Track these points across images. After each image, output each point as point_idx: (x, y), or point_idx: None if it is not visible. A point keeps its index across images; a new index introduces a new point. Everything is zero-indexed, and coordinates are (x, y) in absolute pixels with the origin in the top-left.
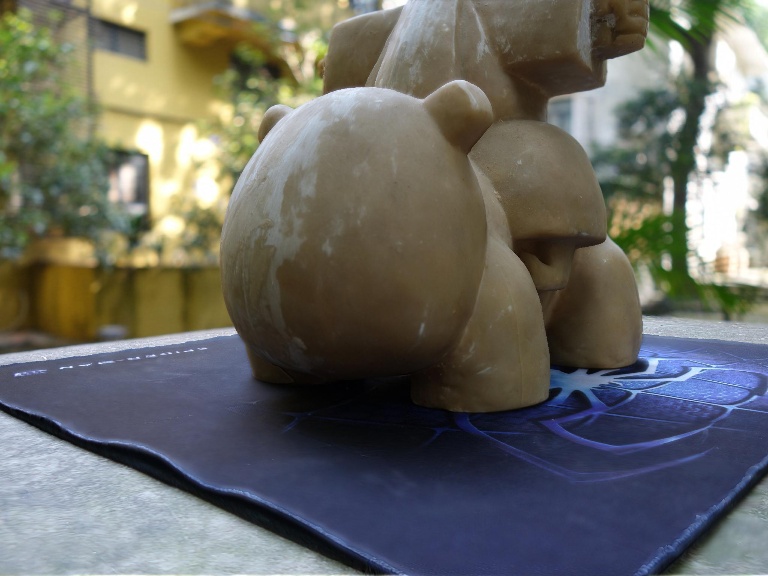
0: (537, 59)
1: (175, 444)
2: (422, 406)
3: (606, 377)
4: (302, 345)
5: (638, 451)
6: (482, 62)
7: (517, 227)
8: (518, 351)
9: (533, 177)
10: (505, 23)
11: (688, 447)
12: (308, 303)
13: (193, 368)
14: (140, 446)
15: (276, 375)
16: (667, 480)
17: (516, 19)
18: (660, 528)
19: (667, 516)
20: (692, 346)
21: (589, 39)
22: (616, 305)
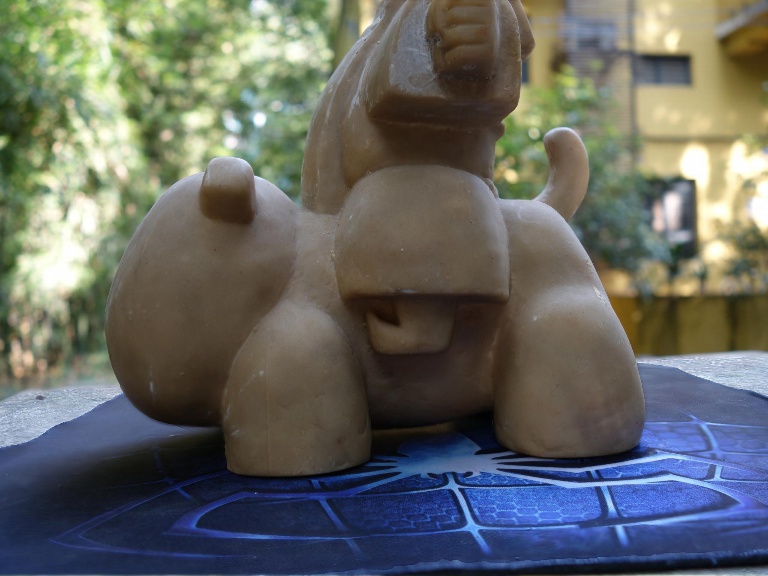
0: (376, 103)
1: (40, 454)
2: None
3: (494, 465)
4: None
5: (186, 536)
6: (352, 116)
7: (340, 287)
8: (266, 418)
9: (353, 233)
10: (370, 70)
11: (235, 547)
12: None
13: None
14: None
15: None
16: (96, 562)
17: None
18: None
19: None
20: None
21: (429, 65)
22: (538, 376)
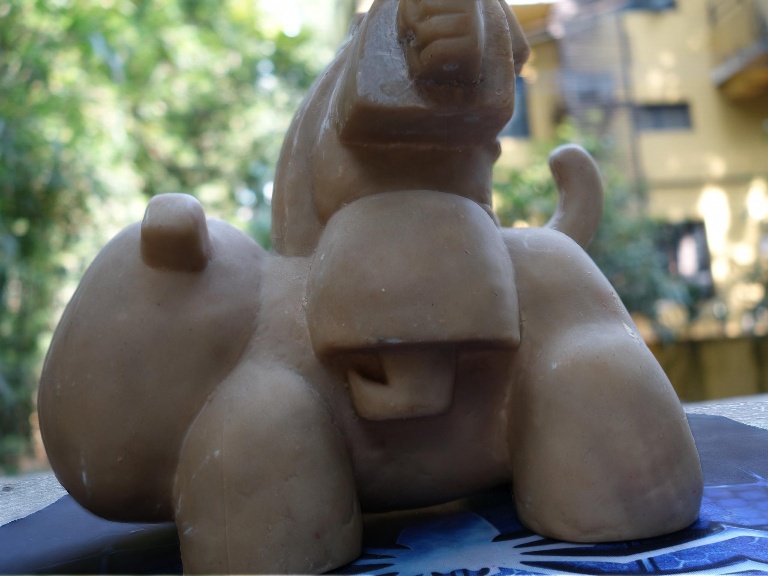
0: (346, 121)
1: None
2: None
3: (517, 557)
4: None
5: None
6: (322, 142)
7: (314, 341)
8: (223, 510)
9: (325, 274)
10: None
11: None
12: None
13: None
14: None
15: None
16: None
17: None
18: None
19: None
20: None
21: (403, 70)
22: (564, 438)
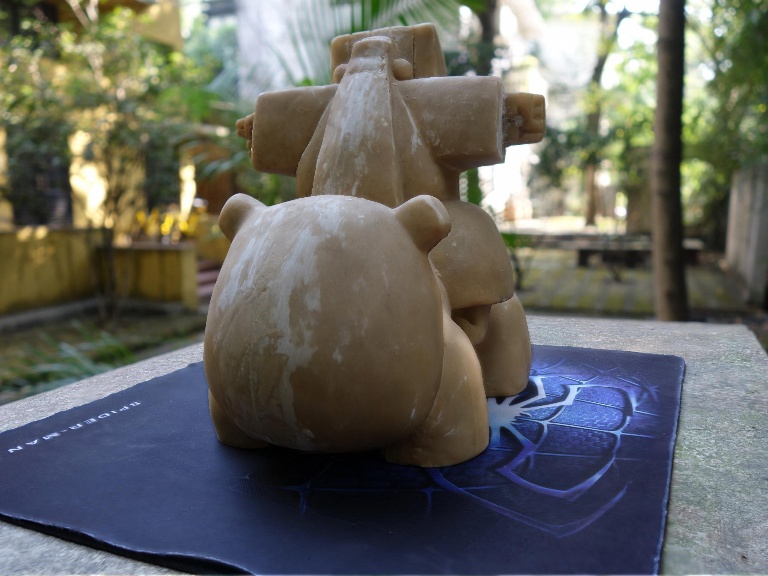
0: (463, 154)
1: (222, 543)
2: (396, 464)
3: (514, 407)
4: (311, 435)
5: (582, 495)
6: (416, 154)
7: (455, 300)
8: (472, 412)
9: (466, 257)
10: (434, 119)
11: (612, 484)
12: (320, 402)
13: (151, 435)
14: (209, 557)
15: (249, 442)
16: (616, 523)
17: (443, 117)
18: (637, 574)
19: (635, 561)
20: (556, 357)
21: (501, 135)
22: (516, 344)
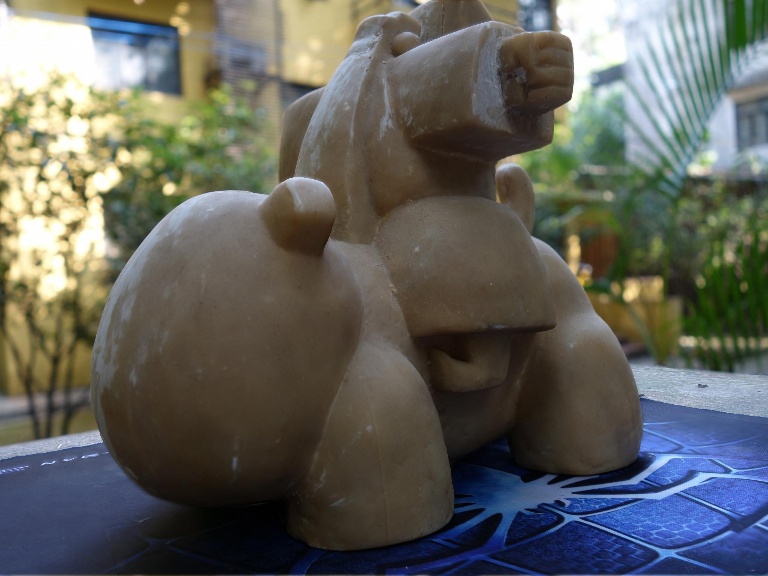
0: (437, 130)
1: None
2: (290, 536)
3: (564, 490)
4: (133, 475)
5: None
6: (385, 139)
7: (413, 324)
8: (380, 479)
9: (429, 266)
10: (408, 93)
11: None
12: (125, 434)
13: None
14: None
15: None
16: None
17: (418, 87)
18: None
19: None
20: (745, 433)
21: (500, 99)
22: (585, 399)
